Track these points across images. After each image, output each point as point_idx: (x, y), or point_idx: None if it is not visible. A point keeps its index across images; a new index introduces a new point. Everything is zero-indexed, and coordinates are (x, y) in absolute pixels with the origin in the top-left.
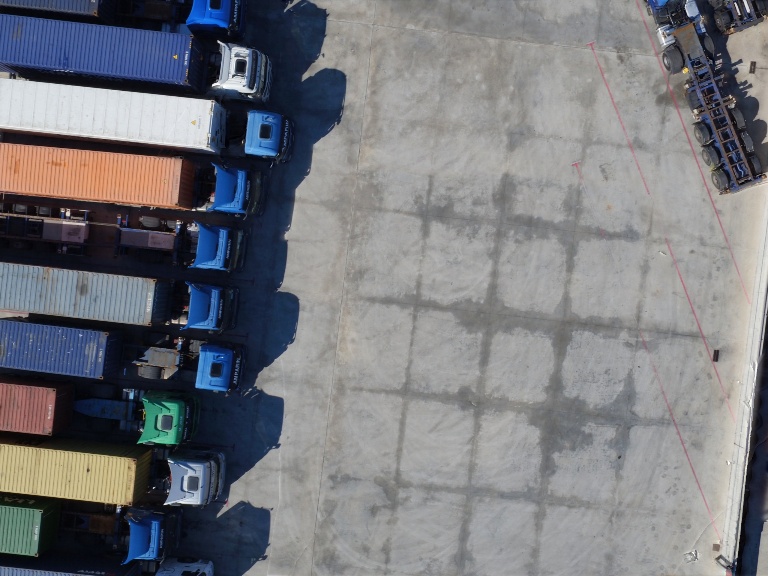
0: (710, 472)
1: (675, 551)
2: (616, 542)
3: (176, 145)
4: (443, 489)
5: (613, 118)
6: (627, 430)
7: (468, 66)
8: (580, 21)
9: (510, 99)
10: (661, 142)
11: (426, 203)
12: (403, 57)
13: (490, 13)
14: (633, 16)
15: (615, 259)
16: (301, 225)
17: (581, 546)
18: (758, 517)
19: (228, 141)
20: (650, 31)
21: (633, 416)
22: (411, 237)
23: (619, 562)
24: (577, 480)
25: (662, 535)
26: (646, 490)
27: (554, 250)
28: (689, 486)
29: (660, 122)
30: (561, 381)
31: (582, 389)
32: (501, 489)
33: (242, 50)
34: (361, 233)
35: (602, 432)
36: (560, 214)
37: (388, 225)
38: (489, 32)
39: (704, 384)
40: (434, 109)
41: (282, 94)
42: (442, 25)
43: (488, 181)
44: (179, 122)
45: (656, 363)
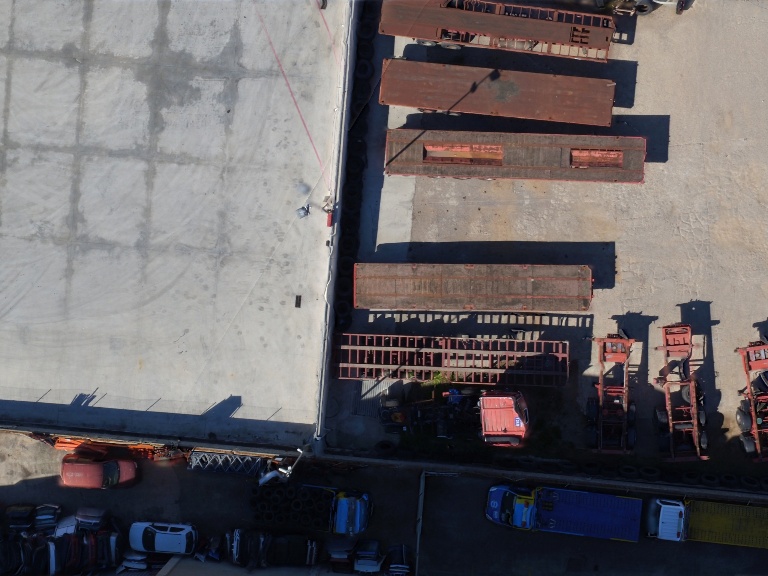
0: (321, 124)
1: (288, 206)
2: (228, 199)
3: None
4: (50, 149)
5: None
6: (235, 83)
7: None
8: None
9: None
10: None
11: None
12: None
13: None
14: None
15: None
16: None
17: (192, 204)
18: (376, 172)
19: None
20: None
21: (241, 68)
22: None
23: (232, 220)
24: (186, 136)
25: (274, 190)
26: (256, 144)
27: None
28: (300, 139)
29: None
30: (166, 35)
31: (188, 42)
32: (109, 147)
33: None
34: None
35: (210, 86)
36: None
37: None
38: None
39: (312, 33)
40: None
41: None
42: None
43: None
44: None
45: (262, 13)
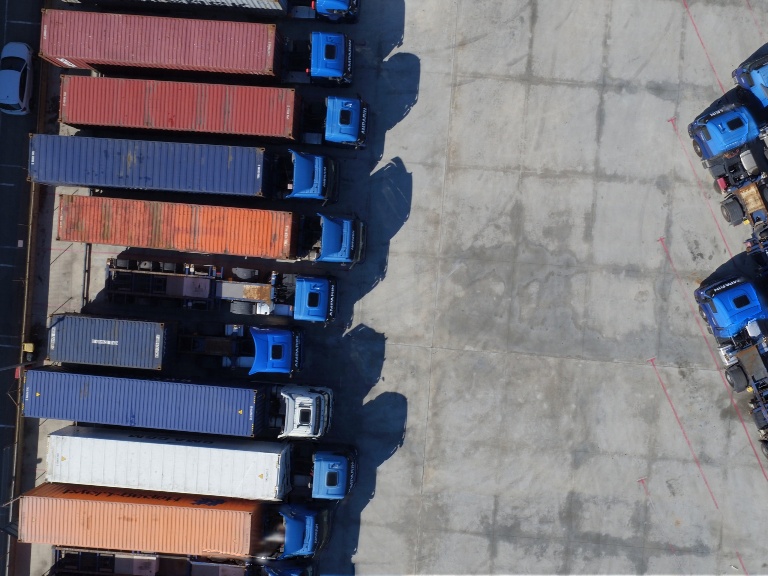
0: None
1: None
2: None
3: (244, 498)
4: None
5: (677, 433)
6: None
7: (529, 386)
8: (640, 338)
9: (572, 417)
10: (727, 456)
11: (492, 523)
12: (463, 379)
13: (549, 332)
14: (693, 331)
15: (686, 574)
16: (367, 548)
17: None
18: None
19: (293, 476)
20: (711, 347)
21: None
22: (478, 557)
23: None
24: None
25: None
26: None
27: (624, 567)
28: None
29: (725, 436)
30: None
31: None
32: None
33: (306, 400)
34: (428, 555)
35: None
36: (628, 530)
37: (455, 546)
38: (548, 351)
39: None
40: (496, 429)
41: (344, 418)
42: (501, 346)
43: (554, 499)
44: (246, 477)
45: None
